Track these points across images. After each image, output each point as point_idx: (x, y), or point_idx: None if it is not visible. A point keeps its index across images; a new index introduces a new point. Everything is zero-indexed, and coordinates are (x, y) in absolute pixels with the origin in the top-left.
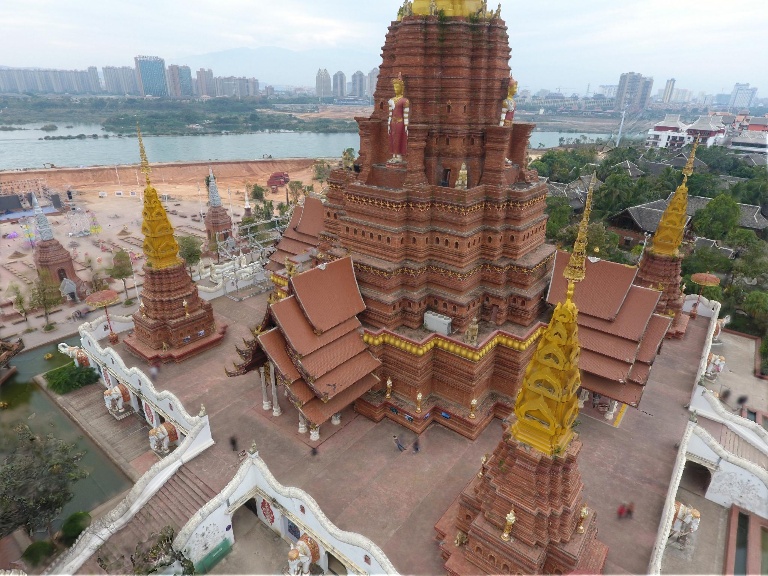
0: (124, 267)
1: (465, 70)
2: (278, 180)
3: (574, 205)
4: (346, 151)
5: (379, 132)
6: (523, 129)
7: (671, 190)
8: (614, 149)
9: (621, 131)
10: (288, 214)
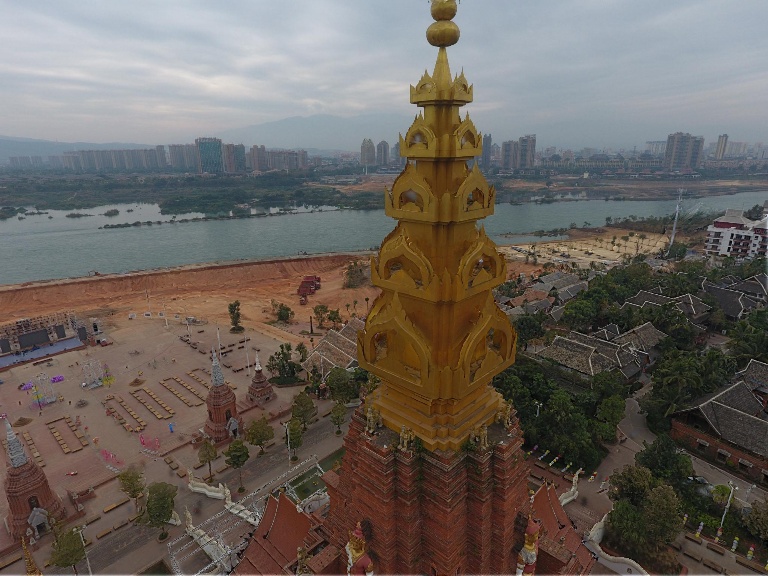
0: (73, 552)
1: (456, 523)
2: (308, 288)
3: (629, 371)
4: (380, 248)
5: (337, 568)
6: (553, 562)
7: (750, 354)
8: (671, 276)
9: (676, 226)
10: (286, 425)
